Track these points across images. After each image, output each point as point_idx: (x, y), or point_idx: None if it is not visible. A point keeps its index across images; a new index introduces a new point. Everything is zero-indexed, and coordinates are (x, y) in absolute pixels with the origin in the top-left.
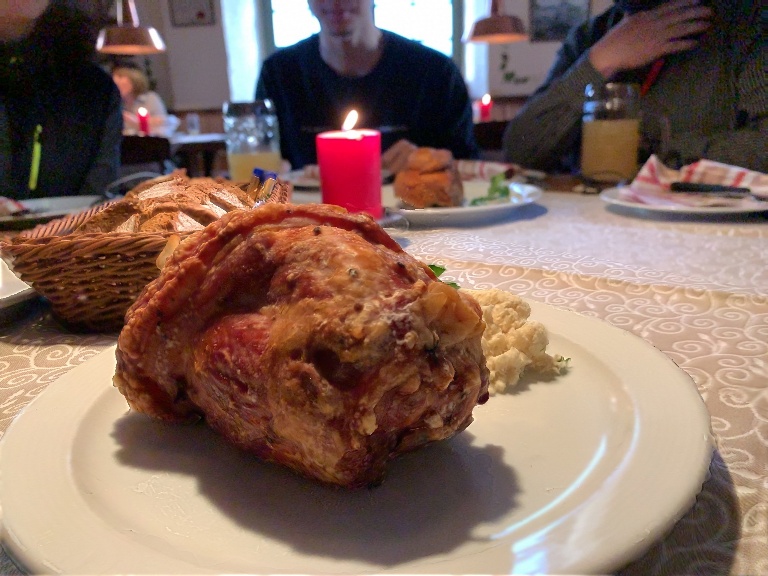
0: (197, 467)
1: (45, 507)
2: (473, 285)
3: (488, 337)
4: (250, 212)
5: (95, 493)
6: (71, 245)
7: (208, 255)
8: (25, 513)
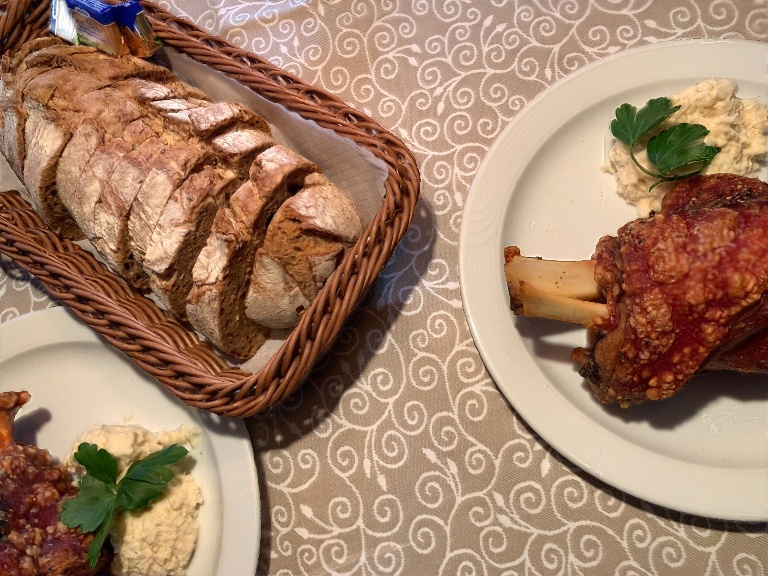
0: (703, 388)
1: (759, 492)
2: (489, 1)
3: (737, 139)
4: (767, 277)
5: (726, 458)
6: (318, 350)
7: (731, 320)
8: (764, 504)
